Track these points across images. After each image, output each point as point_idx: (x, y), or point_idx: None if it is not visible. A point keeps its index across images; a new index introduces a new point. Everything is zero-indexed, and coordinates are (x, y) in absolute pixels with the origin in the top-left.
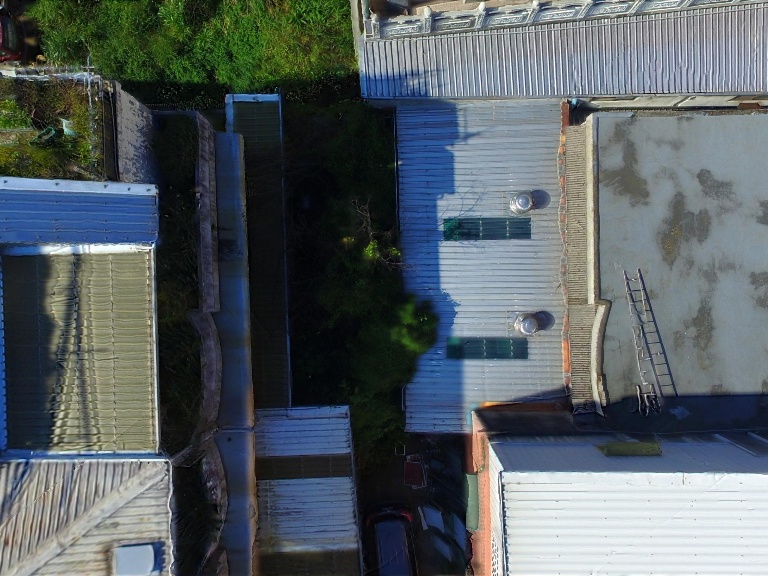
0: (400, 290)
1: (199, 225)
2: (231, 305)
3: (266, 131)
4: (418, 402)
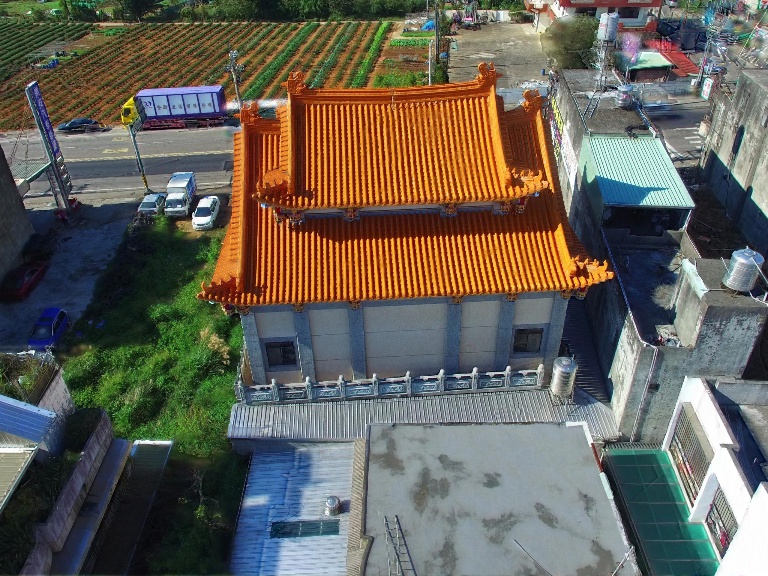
0: (222, 571)
1: (74, 470)
2: (72, 550)
3: (155, 462)
4: None
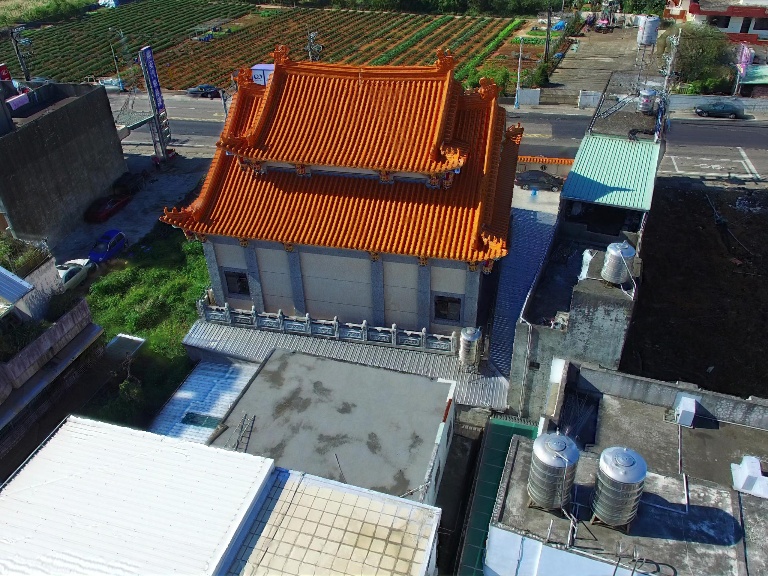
0: None
1: (43, 333)
2: (27, 390)
3: (126, 351)
4: None
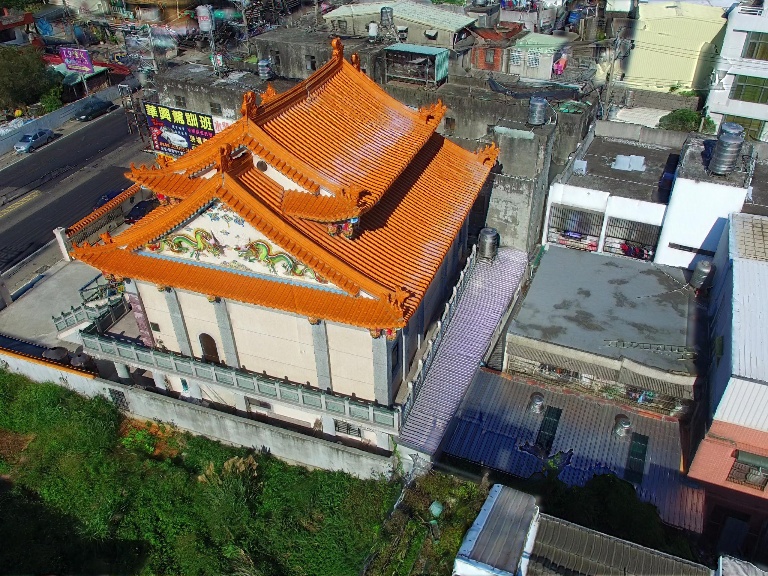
0: None
1: None
2: None
3: None
4: (676, 517)
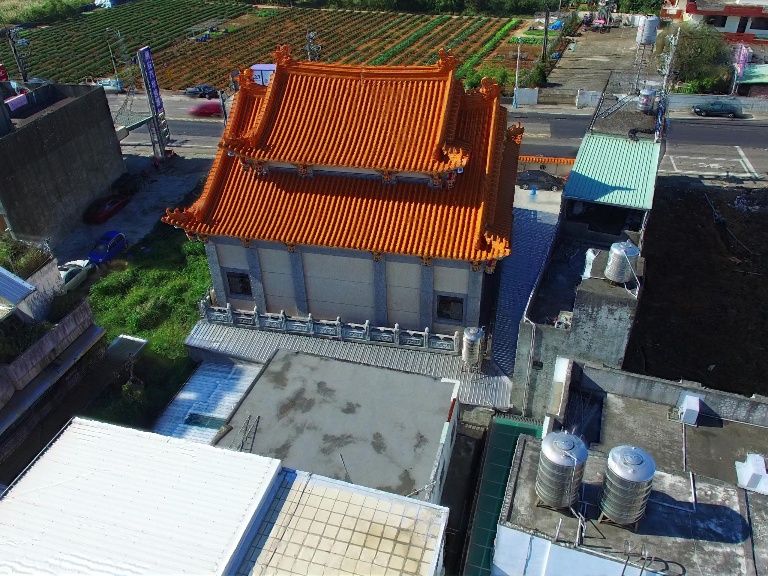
0: None
1: (45, 335)
2: (30, 392)
3: (127, 352)
4: None
